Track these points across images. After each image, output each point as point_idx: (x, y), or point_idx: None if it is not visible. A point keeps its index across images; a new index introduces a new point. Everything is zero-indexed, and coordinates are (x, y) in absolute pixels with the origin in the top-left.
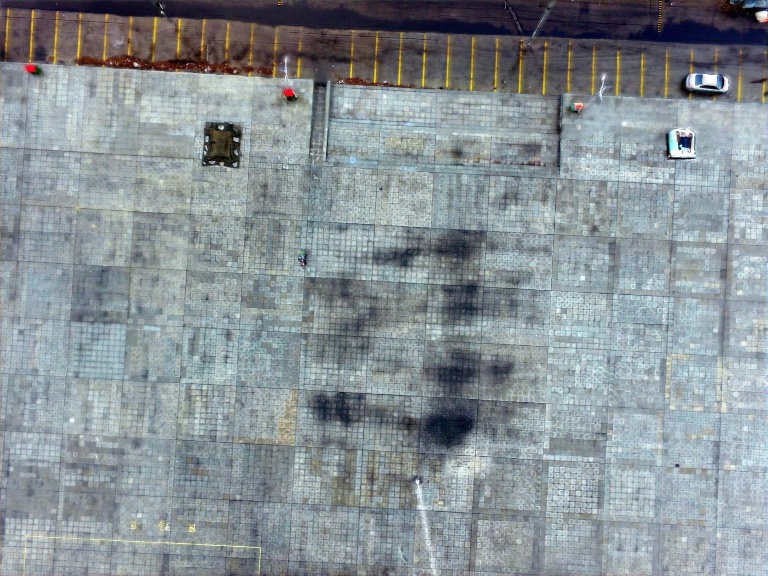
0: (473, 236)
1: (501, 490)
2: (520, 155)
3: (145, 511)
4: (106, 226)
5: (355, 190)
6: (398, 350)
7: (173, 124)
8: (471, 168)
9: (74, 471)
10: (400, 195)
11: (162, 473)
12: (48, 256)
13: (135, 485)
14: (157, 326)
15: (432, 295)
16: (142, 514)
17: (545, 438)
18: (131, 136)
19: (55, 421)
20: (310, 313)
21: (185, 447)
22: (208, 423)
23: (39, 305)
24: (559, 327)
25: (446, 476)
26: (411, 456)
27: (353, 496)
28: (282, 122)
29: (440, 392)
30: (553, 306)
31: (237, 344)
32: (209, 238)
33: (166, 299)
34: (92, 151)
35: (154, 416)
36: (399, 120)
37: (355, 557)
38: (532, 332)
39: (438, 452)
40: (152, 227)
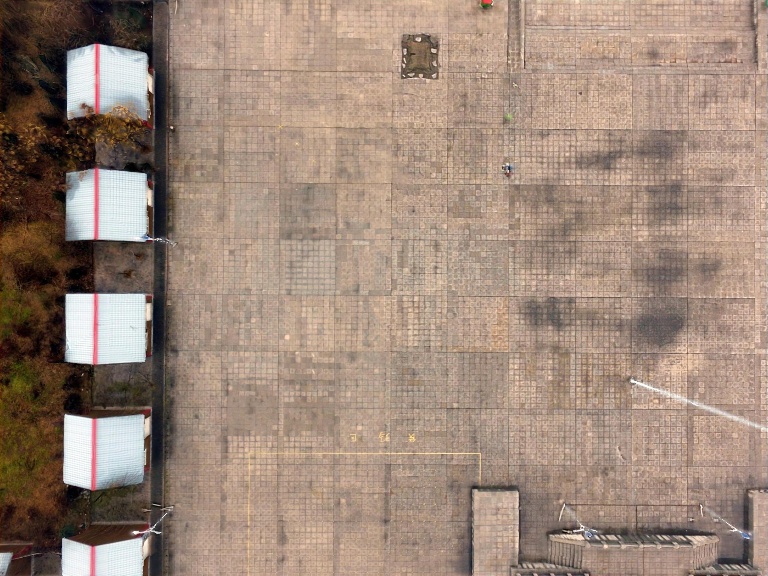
0: (675, 136)
1: (715, 386)
2: (716, 53)
3: (364, 423)
4: (309, 143)
5: (555, 96)
6: (605, 253)
7: (370, 38)
8: (669, 68)
9: (292, 387)
10: (600, 98)
11: (379, 385)
12: (254, 176)
13: (353, 398)
14: (366, 240)
15: (637, 196)
16: (362, 426)
17: (756, 332)
18: (329, 52)
19: (270, 339)
20: (516, 220)
21: (400, 359)
22: (421, 334)
23: (248, 225)
24: (765, 222)
25: (659, 375)
26: (624, 357)
27: (569, 399)
28: (479, 31)
29: (649, 292)
30: (758, 201)
31: (446, 254)
32: (412, 150)
33: (373, 213)
34: (291, 69)
35: (368, 329)
36: (593, 24)
37: (574, 458)
38: (738, 228)
39: (650, 351)
40: (355, 142)
